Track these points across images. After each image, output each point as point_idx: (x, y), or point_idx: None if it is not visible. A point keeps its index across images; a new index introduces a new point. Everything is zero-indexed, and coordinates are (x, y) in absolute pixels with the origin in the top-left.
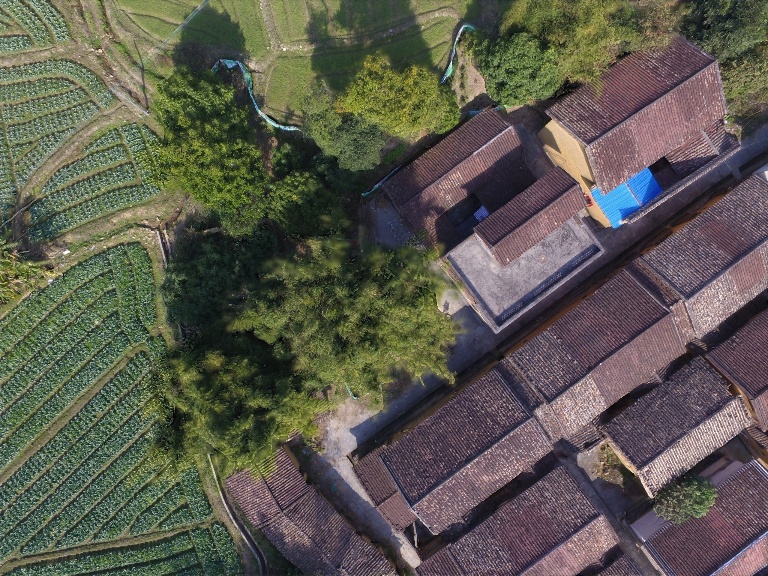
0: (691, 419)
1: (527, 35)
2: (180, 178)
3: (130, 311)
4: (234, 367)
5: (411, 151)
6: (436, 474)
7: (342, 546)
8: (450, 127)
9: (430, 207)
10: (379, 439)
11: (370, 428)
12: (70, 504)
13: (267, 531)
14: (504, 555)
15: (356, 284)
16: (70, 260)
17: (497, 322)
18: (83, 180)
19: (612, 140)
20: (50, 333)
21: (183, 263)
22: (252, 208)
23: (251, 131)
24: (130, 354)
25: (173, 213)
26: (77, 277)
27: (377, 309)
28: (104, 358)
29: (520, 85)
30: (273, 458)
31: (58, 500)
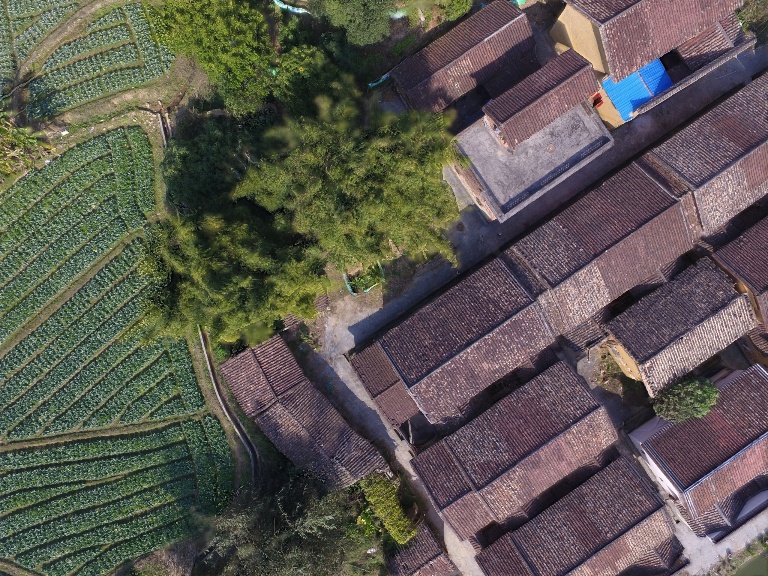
0: (695, 316)
1: None
2: (185, 27)
3: (128, 195)
4: (233, 229)
5: (421, 42)
6: (435, 357)
7: (336, 438)
8: (462, 12)
9: (438, 94)
10: (377, 338)
11: (368, 326)
12: (60, 390)
13: (260, 421)
14: (501, 445)
15: (362, 142)
16: (68, 141)
17: (502, 211)
18: (85, 59)
19: (627, 22)
20: (45, 215)
21: (184, 140)
22: (257, 82)
23: (259, 4)
24: (127, 240)
25: (176, 97)
26: (75, 158)
27: (383, 165)
28: (100, 242)
29: None
30: (269, 344)
31: (48, 385)
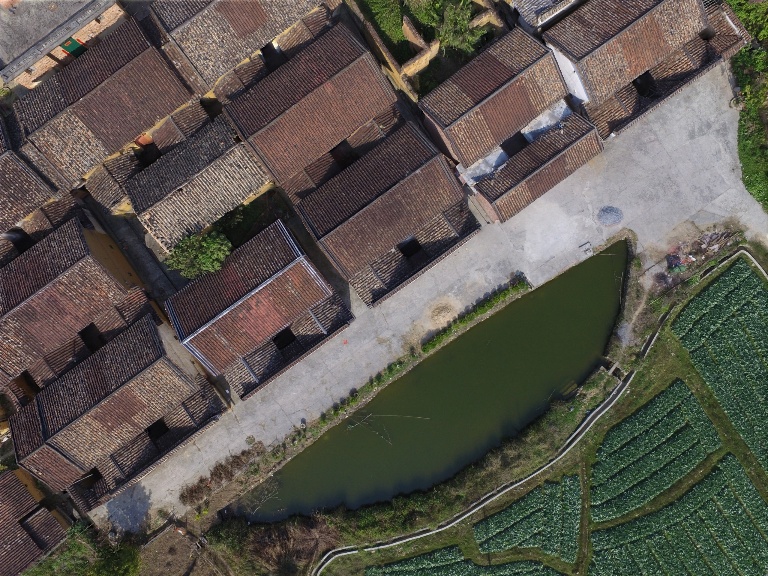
0: (195, 167)
1: None
2: None
3: None
4: None
5: None
6: None
7: None
8: None
9: None
10: None
11: None
12: None
13: None
14: (0, 299)
15: None
16: None
17: None
18: None
19: None
20: None
21: None
22: None
23: None
24: None
25: None
26: None
27: None
28: None
29: None
30: None
31: None
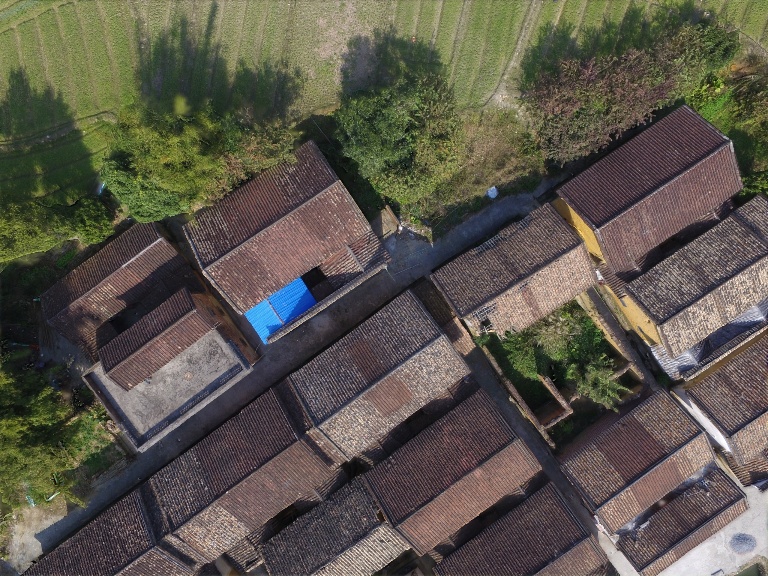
0: (338, 544)
1: (120, 162)
2: None
3: None
4: None
5: (83, 256)
6: None
7: None
8: (98, 239)
9: (84, 319)
10: None
11: (54, 534)
12: None
13: None
14: None
15: None
16: None
17: (142, 441)
18: None
19: (233, 262)
20: None
21: None
22: None
23: None
24: None
25: None
26: None
27: None
28: None
29: (141, 205)
30: None
31: None
